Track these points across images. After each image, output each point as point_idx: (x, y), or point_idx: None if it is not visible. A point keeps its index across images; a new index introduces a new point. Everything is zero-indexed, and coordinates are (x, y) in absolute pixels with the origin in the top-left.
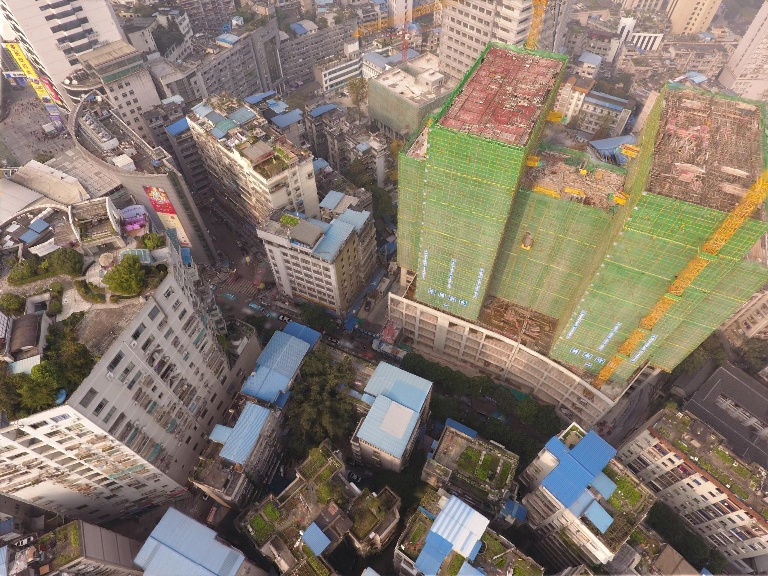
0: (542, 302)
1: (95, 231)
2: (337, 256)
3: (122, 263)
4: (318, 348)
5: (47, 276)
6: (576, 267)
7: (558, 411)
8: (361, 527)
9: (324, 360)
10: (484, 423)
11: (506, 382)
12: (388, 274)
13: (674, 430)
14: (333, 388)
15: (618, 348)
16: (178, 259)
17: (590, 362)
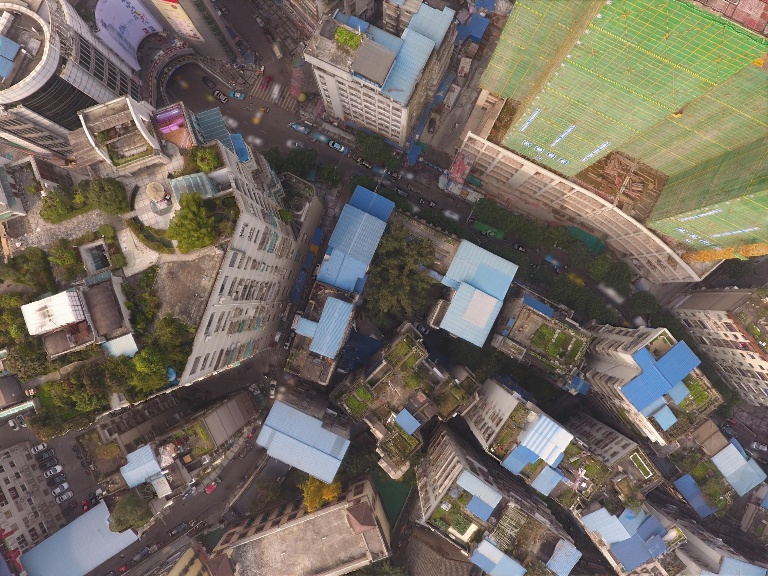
0: (658, 159)
1: (125, 145)
2: (412, 94)
3: (184, 211)
4: (395, 226)
5: (87, 210)
6: (729, 140)
7: (628, 260)
8: (445, 408)
9: (401, 237)
10: (553, 279)
11: (579, 224)
12: (457, 76)
13: (754, 314)
14: (411, 268)
15: (739, 247)
16: (234, 161)
17: (692, 240)
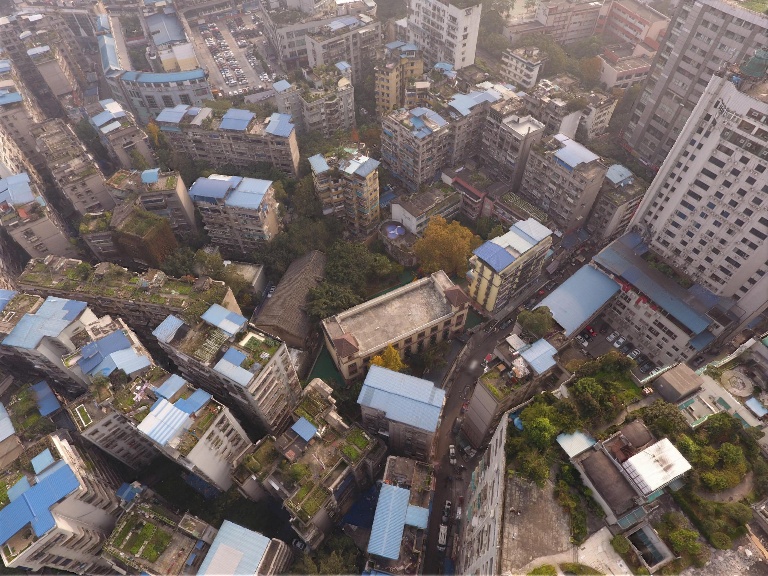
0: None
1: None
2: None
3: None
4: None
5: None
6: None
7: None
8: None
9: None
10: None
11: None
12: None
13: None
14: None
15: None
16: None
17: None
